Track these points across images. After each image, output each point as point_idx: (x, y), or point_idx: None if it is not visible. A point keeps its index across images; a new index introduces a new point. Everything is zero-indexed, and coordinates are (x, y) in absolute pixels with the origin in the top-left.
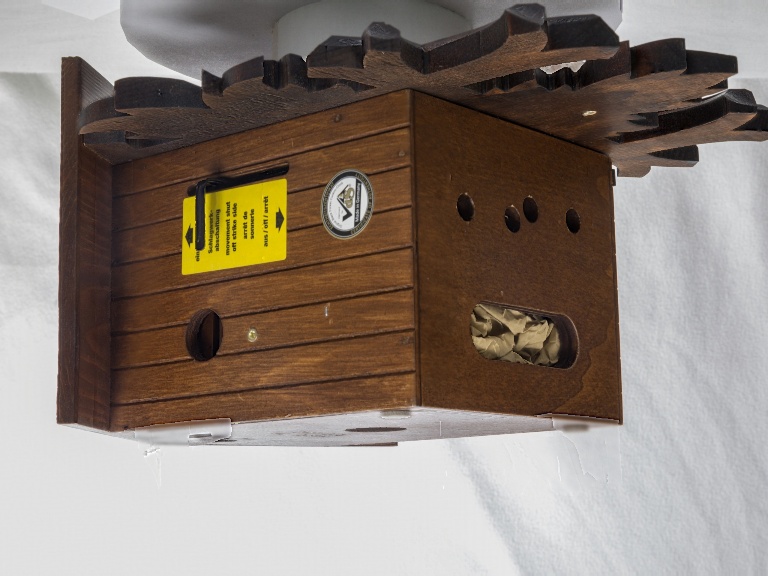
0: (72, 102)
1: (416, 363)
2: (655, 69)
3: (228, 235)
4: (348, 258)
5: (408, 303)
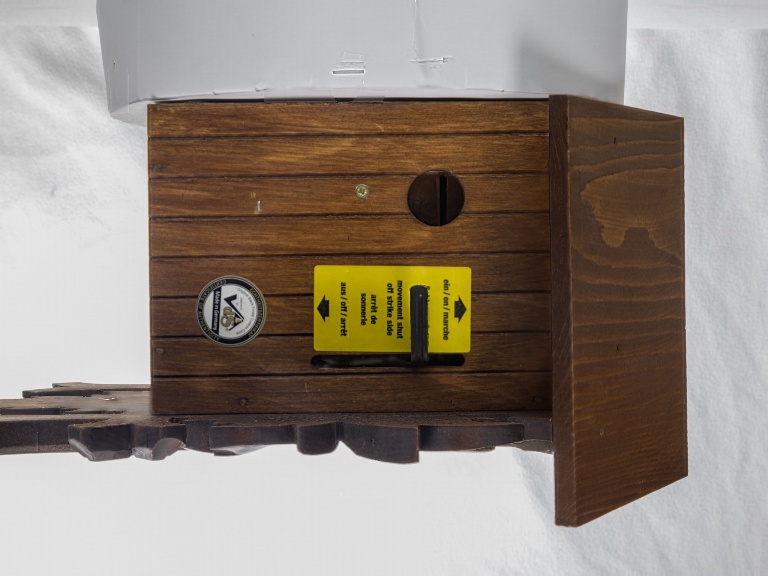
0: (561, 471)
1: (148, 145)
2: None
3: (399, 302)
4: (231, 256)
5: (154, 203)
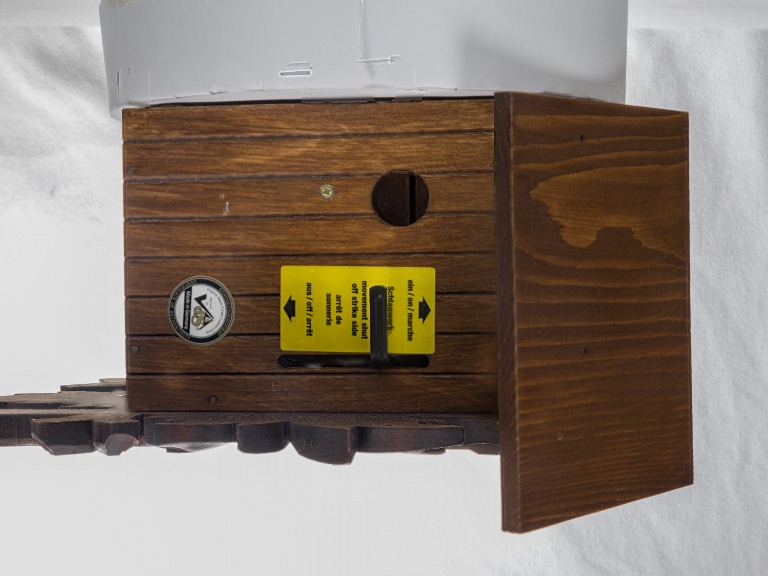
0: (506, 476)
1: None
2: (4, 405)
3: (364, 303)
4: (201, 257)
5: (128, 205)
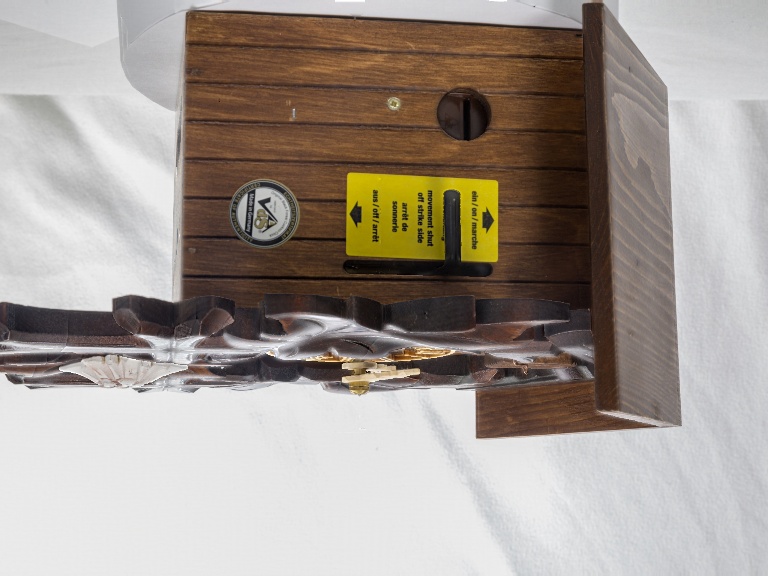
0: (602, 356)
1: (185, 51)
2: None
3: (430, 211)
4: (265, 161)
5: (190, 106)
